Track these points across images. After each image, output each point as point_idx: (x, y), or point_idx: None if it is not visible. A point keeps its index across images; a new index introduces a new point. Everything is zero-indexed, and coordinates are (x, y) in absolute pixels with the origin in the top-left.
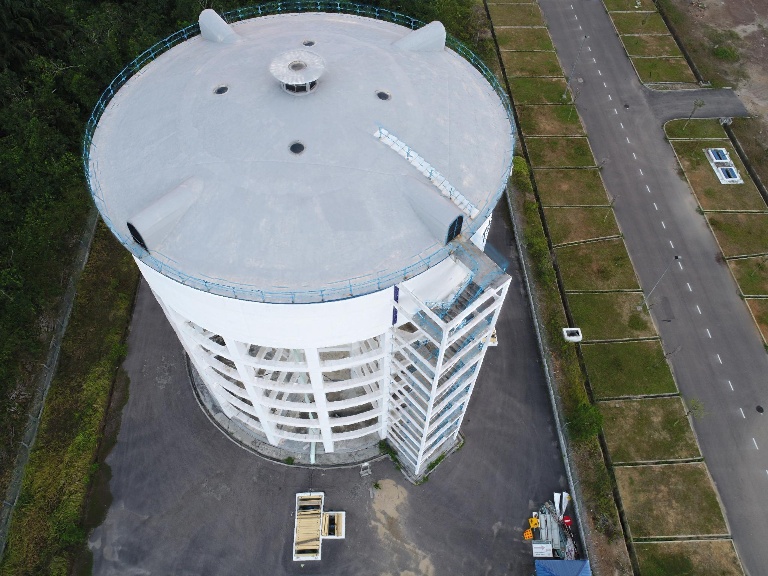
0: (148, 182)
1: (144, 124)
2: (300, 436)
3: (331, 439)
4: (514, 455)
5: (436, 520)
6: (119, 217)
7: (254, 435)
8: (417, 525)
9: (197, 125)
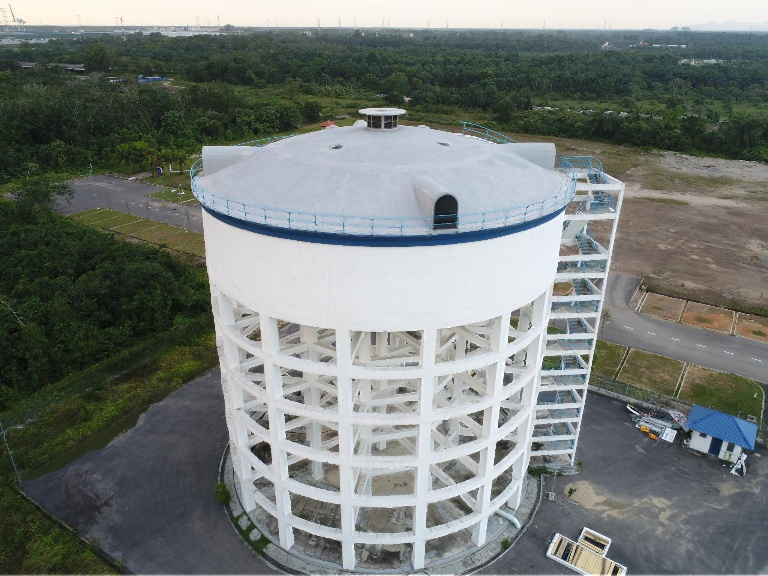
0: (381, 201)
1: (303, 188)
2: (506, 491)
3: (523, 473)
4: (583, 413)
5: (619, 477)
6: (394, 229)
7: (460, 556)
8: (619, 489)
9: (361, 161)
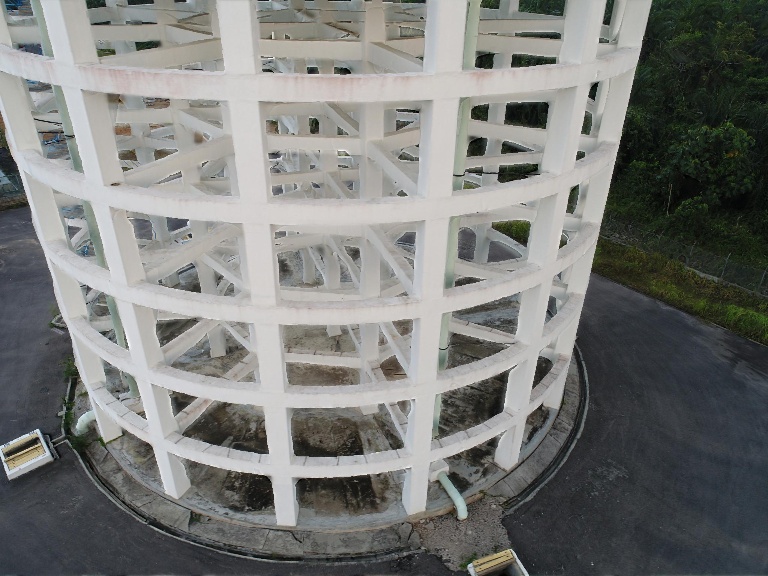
0: None
1: None
2: None
3: None
4: None
5: None
6: None
7: None
8: None
9: None
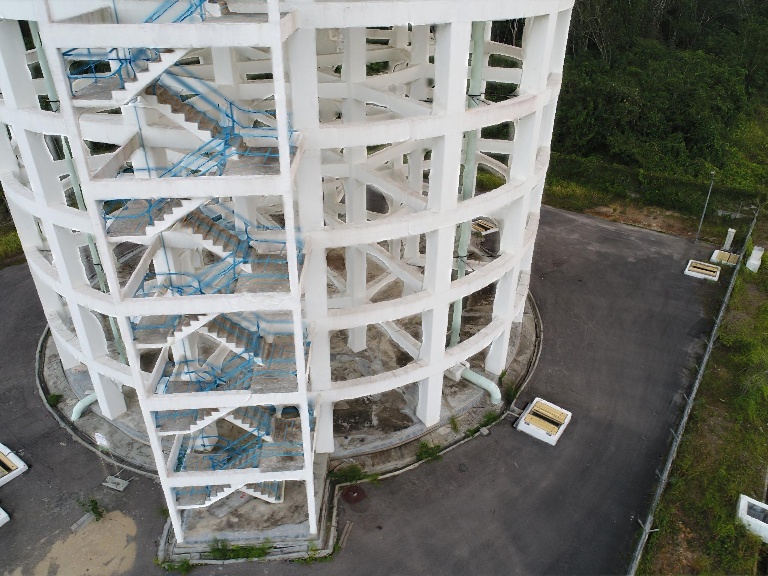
0: None
1: None
2: (66, 334)
3: (94, 360)
4: None
5: None
6: None
7: None
8: None
9: None
